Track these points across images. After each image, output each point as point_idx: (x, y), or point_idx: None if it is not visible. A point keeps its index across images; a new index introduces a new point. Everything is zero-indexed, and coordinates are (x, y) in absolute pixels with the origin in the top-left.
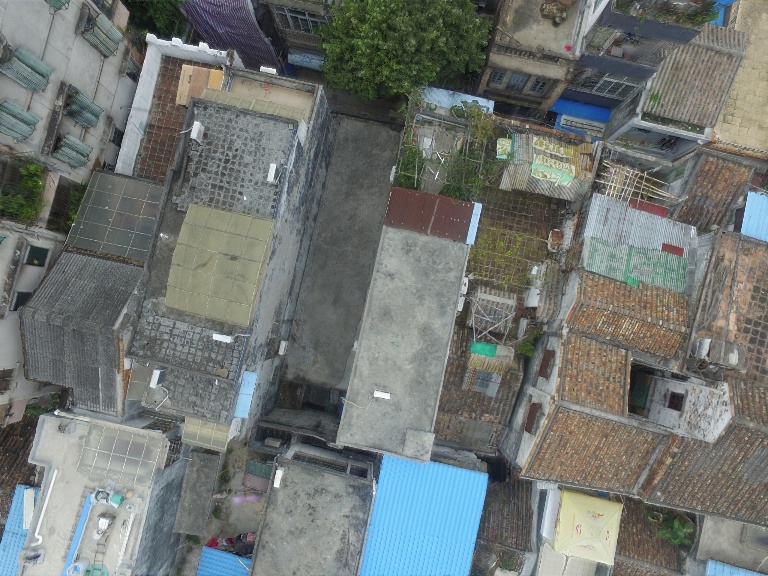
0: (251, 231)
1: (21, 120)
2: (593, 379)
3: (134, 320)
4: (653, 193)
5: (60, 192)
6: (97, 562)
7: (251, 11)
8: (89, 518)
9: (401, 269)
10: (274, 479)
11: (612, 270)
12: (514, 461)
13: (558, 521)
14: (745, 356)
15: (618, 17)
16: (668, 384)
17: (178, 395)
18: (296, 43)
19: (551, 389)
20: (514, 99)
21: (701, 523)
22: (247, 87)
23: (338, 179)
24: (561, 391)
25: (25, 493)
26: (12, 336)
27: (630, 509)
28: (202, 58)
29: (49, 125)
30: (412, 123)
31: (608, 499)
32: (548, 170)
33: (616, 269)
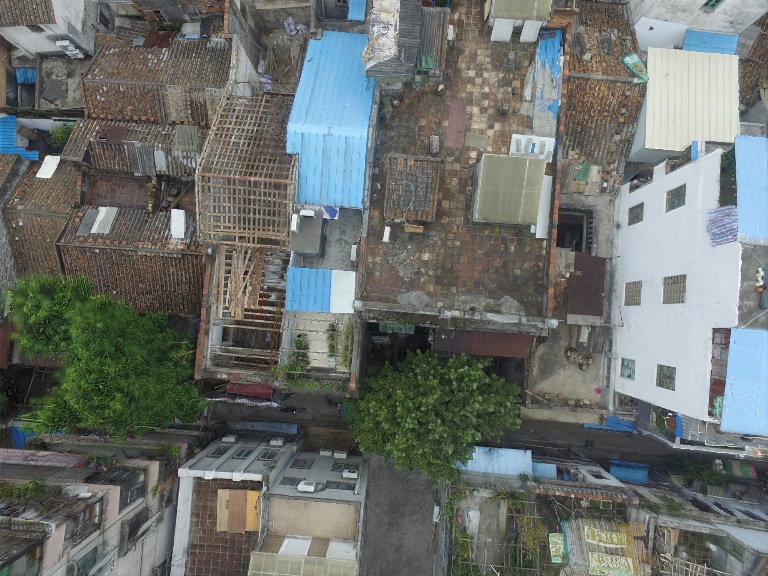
0: None
1: None
2: None
3: None
4: None
5: None
6: None
7: None
8: None
9: None
10: None
11: None
12: None
13: None
14: None
15: None
16: None
17: None
18: None
19: None
20: None
21: None
22: (286, 500)
23: (379, 510)
24: None
25: None
26: None
27: None
28: None
29: None
30: None
31: None
32: (606, 569)
33: None
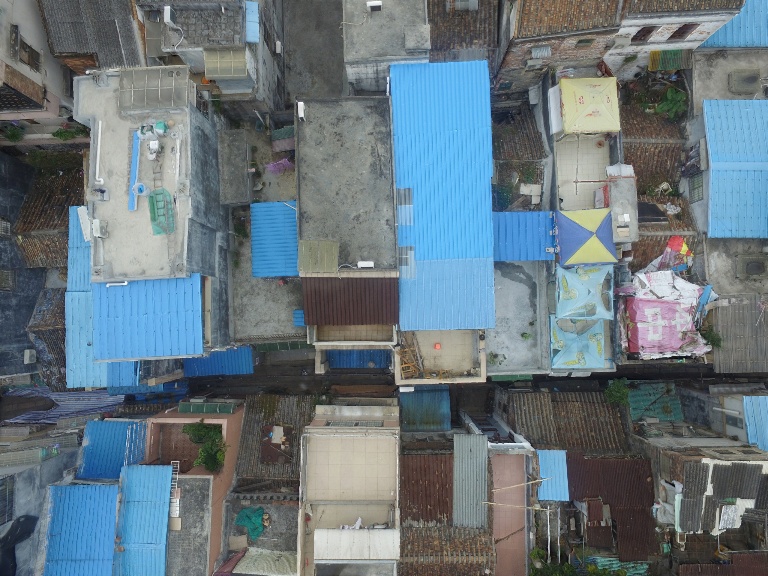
0: None
1: None
2: None
3: None
4: None
5: None
6: (157, 188)
7: None
8: (140, 153)
9: None
10: (298, 110)
11: None
12: None
13: (562, 106)
14: None
15: None
16: None
17: (192, 33)
18: None
19: None
20: None
21: (691, 86)
22: None
23: None
24: None
25: (78, 211)
26: (31, 16)
27: (627, 111)
28: None
29: None
30: None
31: None
32: None
33: None
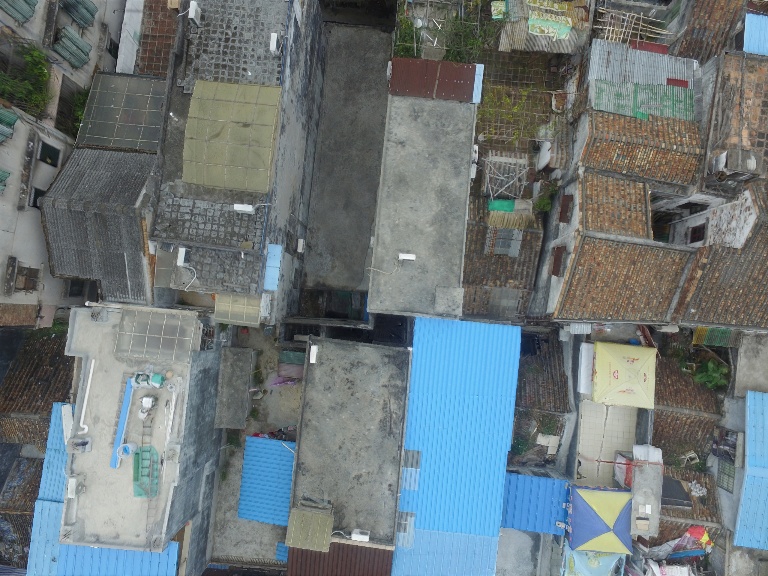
0: (260, 98)
1: None
2: (614, 210)
3: (154, 202)
4: (651, 32)
5: (65, 91)
6: (145, 444)
7: None
8: (132, 402)
9: (411, 135)
10: (309, 355)
11: (620, 107)
12: (544, 313)
13: (594, 372)
14: (762, 162)
15: None
16: (687, 223)
17: (206, 274)
18: None
19: (574, 227)
20: None
21: (735, 362)
22: None
23: (335, 86)
24: (585, 222)
25: (63, 409)
26: (34, 234)
27: (663, 364)
28: None
29: (47, 16)
30: (404, 0)
31: (641, 346)
32: (545, 24)
33: (624, 106)
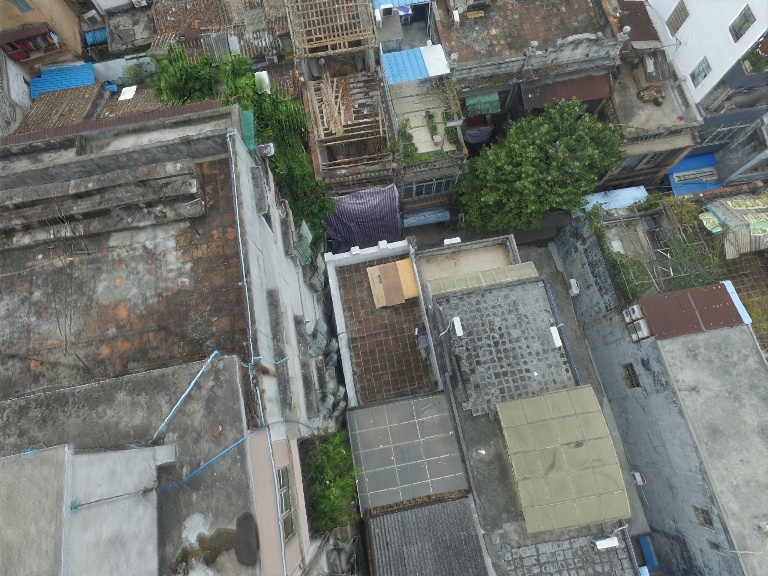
0: (576, 406)
1: (331, 393)
2: None
3: None
4: None
5: None
6: None
7: (396, 196)
8: None
9: (700, 378)
10: None
11: None
12: None
13: None
14: None
15: (752, 77)
16: None
17: None
18: (413, 207)
19: None
20: (631, 177)
21: None
22: (434, 264)
23: None
24: None
25: None
26: None
27: None
28: (379, 255)
29: (319, 385)
30: None
31: None
32: (765, 224)
33: None
